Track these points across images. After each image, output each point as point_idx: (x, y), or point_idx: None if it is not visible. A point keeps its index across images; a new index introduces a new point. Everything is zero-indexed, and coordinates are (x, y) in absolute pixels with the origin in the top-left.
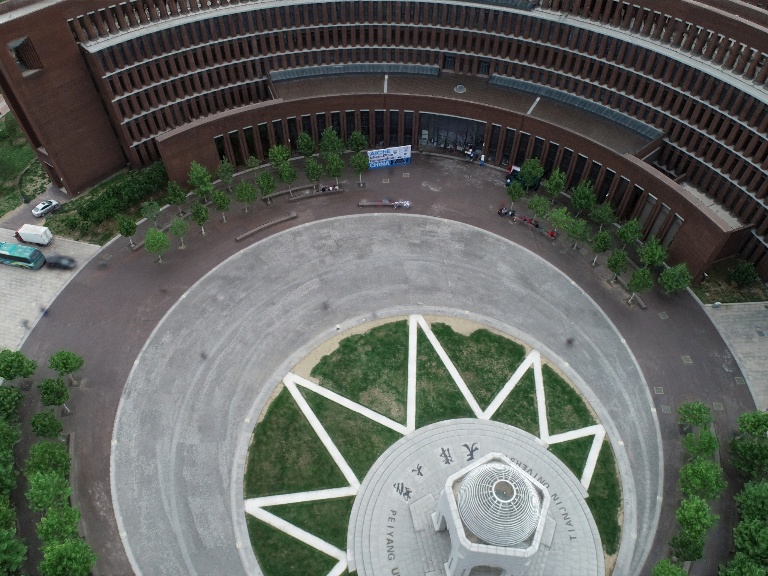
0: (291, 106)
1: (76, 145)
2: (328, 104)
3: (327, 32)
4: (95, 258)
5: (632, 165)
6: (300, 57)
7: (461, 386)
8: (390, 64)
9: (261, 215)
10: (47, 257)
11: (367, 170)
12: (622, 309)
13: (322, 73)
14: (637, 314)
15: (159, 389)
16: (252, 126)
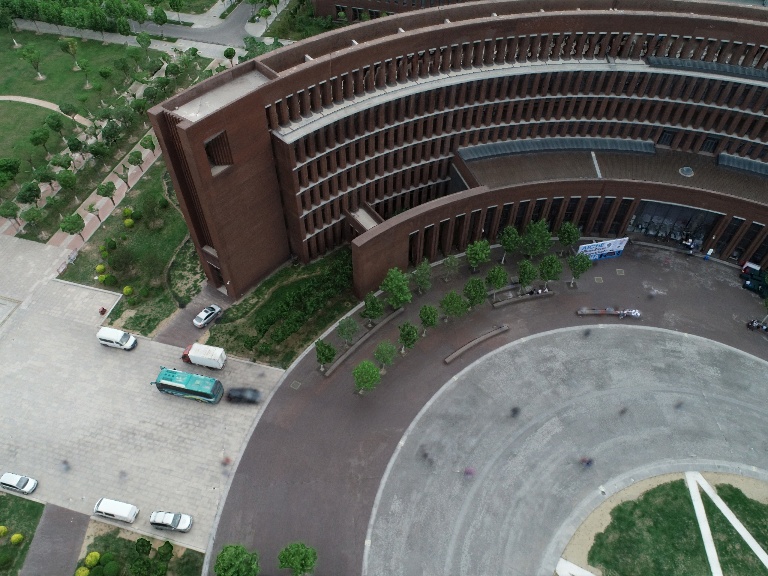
0: (496, 195)
1: (248, 244)
2: (537, 191)
3: (532, 104)
4: (281, 387)
5: None
6: (495, 132)
7: None
8: (595, 138)
9: (465, 327)
10: (223, 385)
11: None
12: None
13: (519, 150)
14: None
15: None
16: (450, 218)
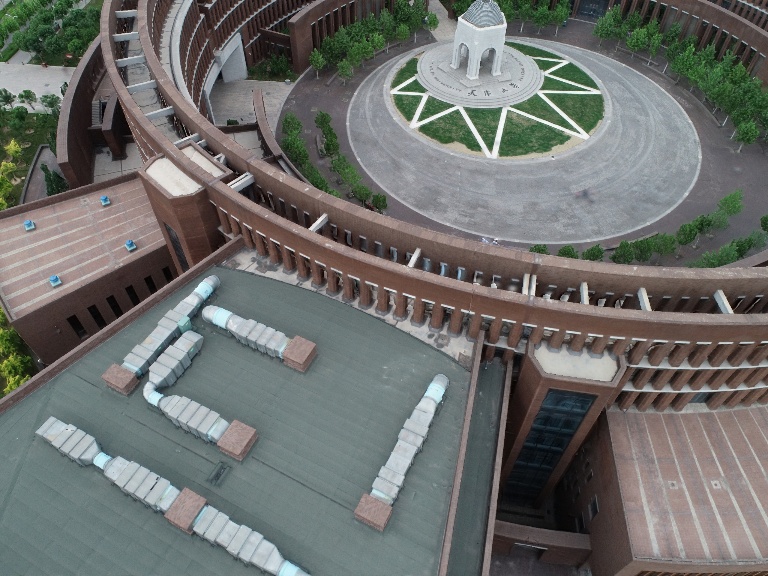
0: None
1: None
2: None
3: None
4: None
5: None
6: None
7: (469, 120)
8: None
9: None
10: None
11: None
12: None
13: None
14: None
15: (675, 141)
16: None
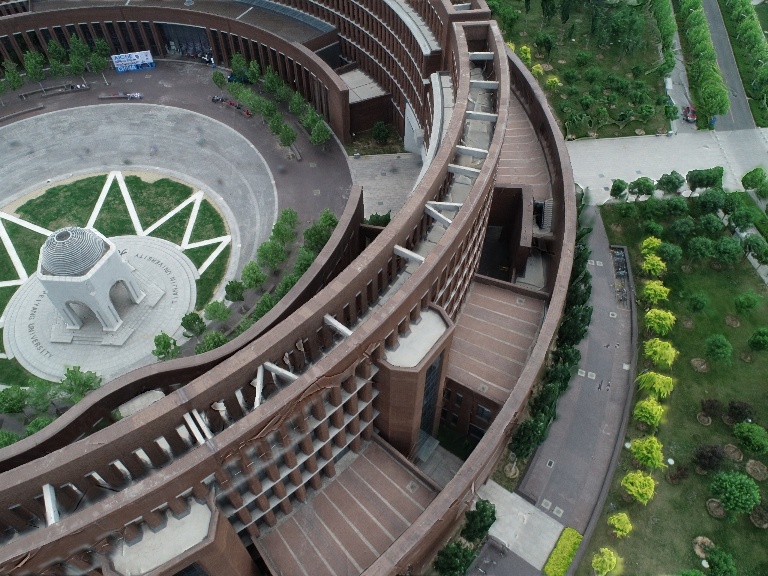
0: (40, 18)
1: None
2: (74, 16)
3: None
4: None
5: (297, 50)
6: None
7: (133, 215)
8: None
9: (14, 107)
10: None
11: (117, 74)
12: (283, 162)
13: None
14: (293, 165)
15: None
16: (8, 35)
